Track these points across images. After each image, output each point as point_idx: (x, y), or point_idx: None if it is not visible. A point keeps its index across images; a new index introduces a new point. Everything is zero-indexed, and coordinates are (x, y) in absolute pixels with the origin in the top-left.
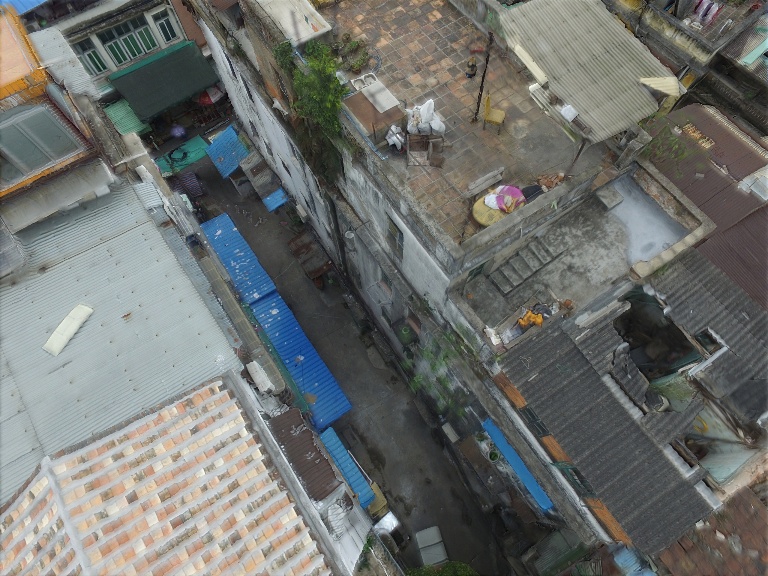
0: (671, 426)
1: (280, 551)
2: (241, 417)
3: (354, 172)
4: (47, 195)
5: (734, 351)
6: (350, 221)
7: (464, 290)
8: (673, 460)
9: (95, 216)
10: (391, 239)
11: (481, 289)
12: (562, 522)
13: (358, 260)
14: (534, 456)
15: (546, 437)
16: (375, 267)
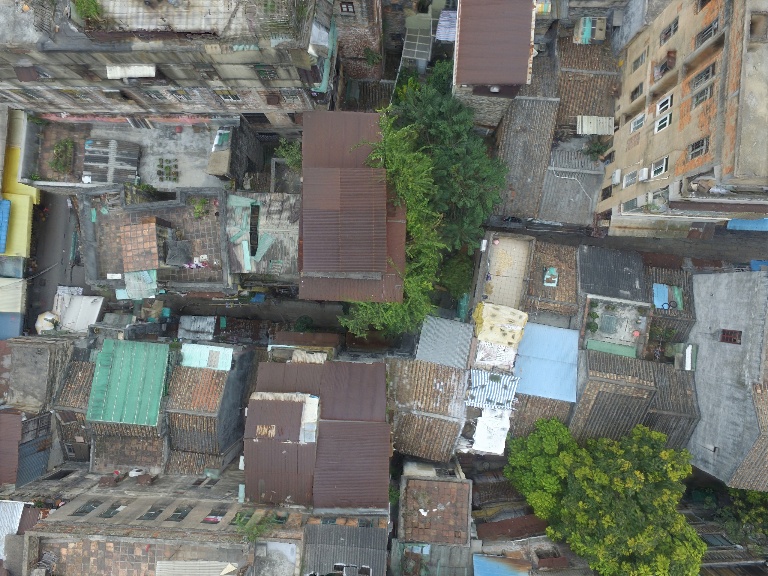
0: None
1: None
2: None
3: None
4: None
5: (348, 564)
6: None
7: None
8: None
9: None
10: None
11: None
12: None
13: None
14: None
15: None
16: None
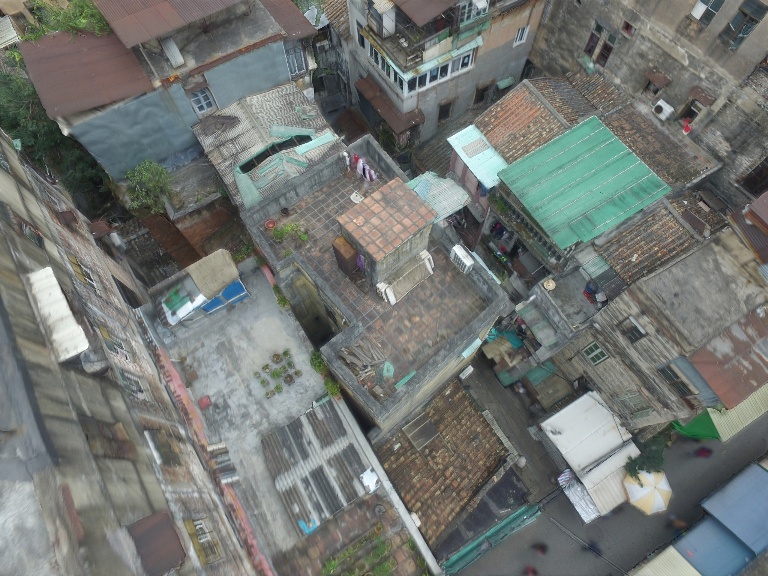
0: None
1: None
2: None
3: None
4: None
5: None
6: None
7: None
8: None
9: None
10: None
11: None
12: None
13: None
14: None
15: None
16: None
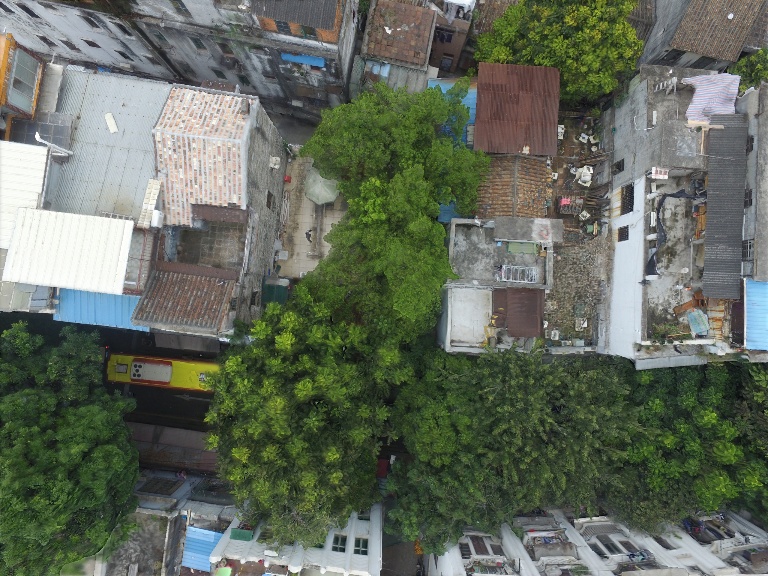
0: None
1: (233, 104)
2: (190, 90)
3: None
4: (48, 91)
5: None
6: (156, 23)
7: (222, 3)
8: None
9: (69, 89)
10: (179, 12)
11: None
12: (337, 69)
13: (179, 53)
14: (301, 47)
15: (291, 30)
16: (188, 43)
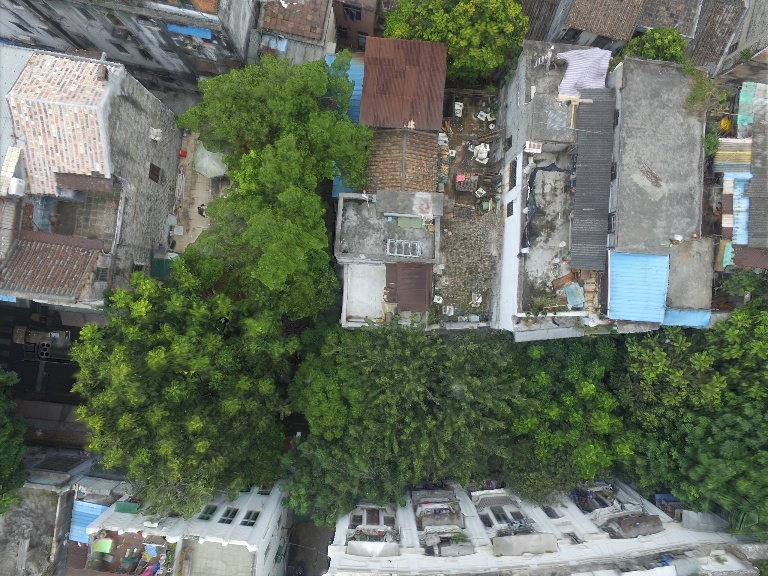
0: None
1: (95, 71)
2: (52, 56)
3: None
4: None
5: None
6: None
7: None
8: None
9: None
10: None
11: None
12: (228, 42)
13: (71, 24)
14: (183, 18)
15: None
16: (76, 13)
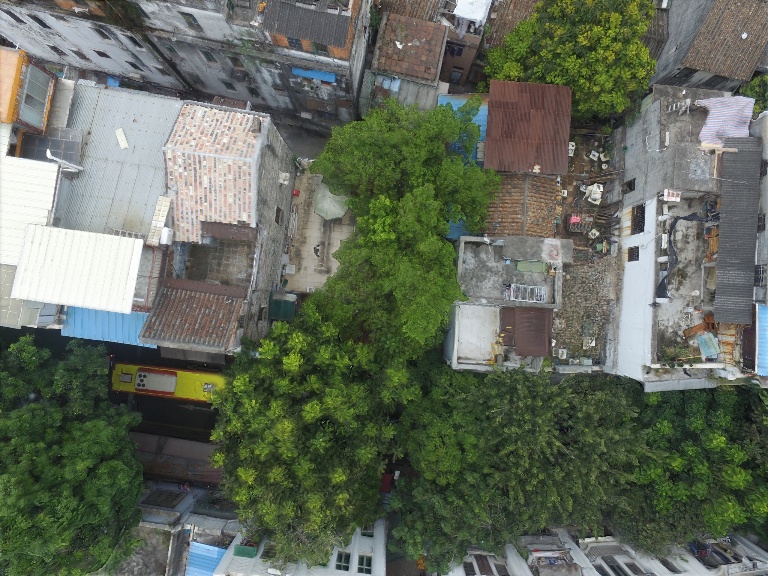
0: (325, 2)
1: (244, 122)
2: (201, 107)
3: (149, 6)
4: (59, 106)
5: None
6: (167, 37)
7: None
8: (332, 12)
9: (80, 104)
10: (191, 26)
11: (240, 13)
12: (348, 84)
13: (189, 65)
14: (312, 63)
15: (303, 46)
16: (199, 56)
